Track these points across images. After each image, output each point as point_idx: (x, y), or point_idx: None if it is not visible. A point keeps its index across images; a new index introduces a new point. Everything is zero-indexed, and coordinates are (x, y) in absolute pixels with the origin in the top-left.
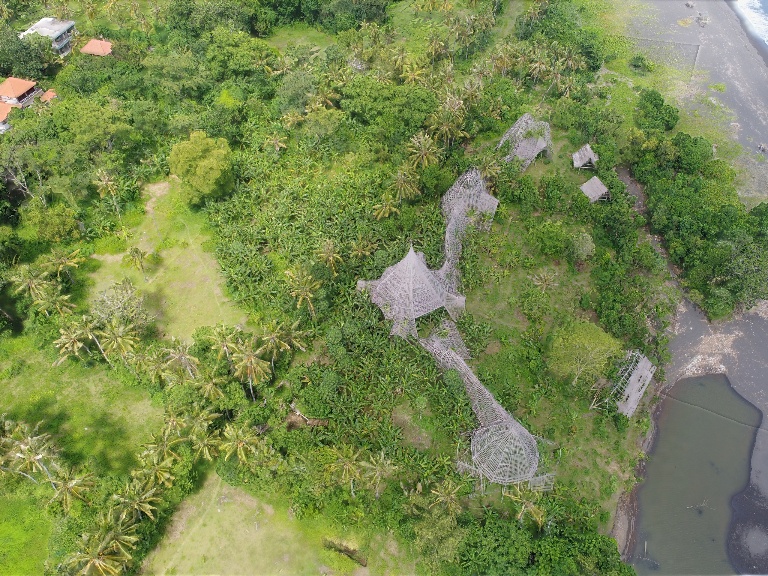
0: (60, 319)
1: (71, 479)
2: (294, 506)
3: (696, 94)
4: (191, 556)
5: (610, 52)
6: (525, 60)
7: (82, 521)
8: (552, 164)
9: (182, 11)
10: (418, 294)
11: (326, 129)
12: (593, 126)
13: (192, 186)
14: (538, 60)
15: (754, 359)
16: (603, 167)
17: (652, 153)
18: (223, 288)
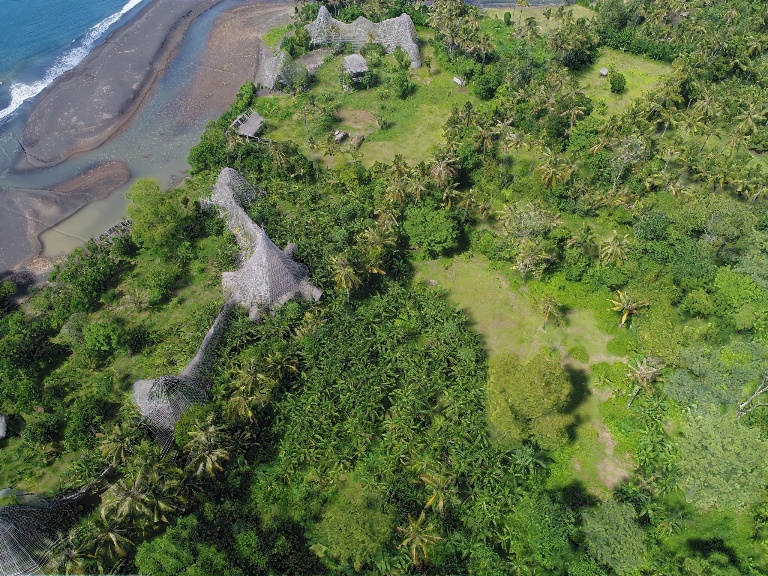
0: None
1: None
2: None
3: None
4: None
5: None
6: None
7: None
8: None
9: None
10: None
11: None
12: None
13: None
14: None
15: (4, 264)
16: None
17: None
18: None
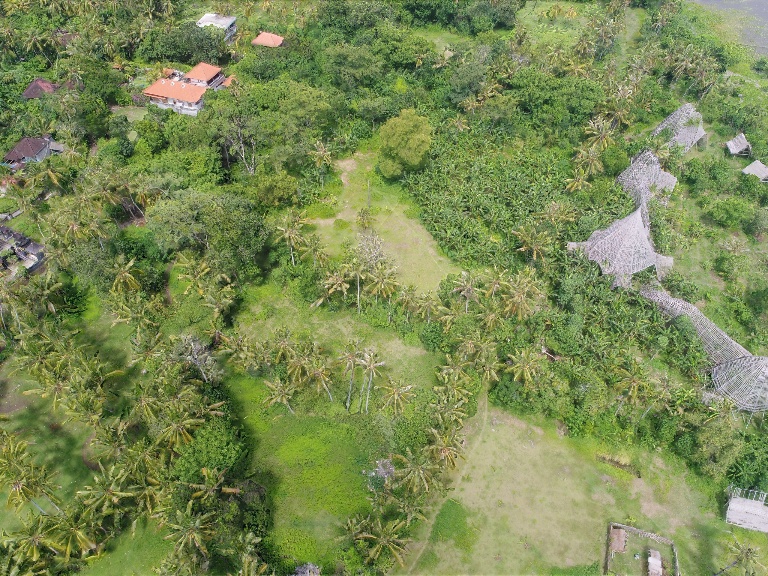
0: None
1: (401, 386)
2: (570, 424)
3: None
4: (480, 466)
5: (731, 57)
6: (671, 59)
7: (415, 422)
8: (706, 151)
9: (339, 10)
10: (638, 251)
11: (505, 113)
12: (741, 118)
13: (394, 159)
14: (685, 59)
15: None
16: (759, 153)
17: None
18: (436, 249)
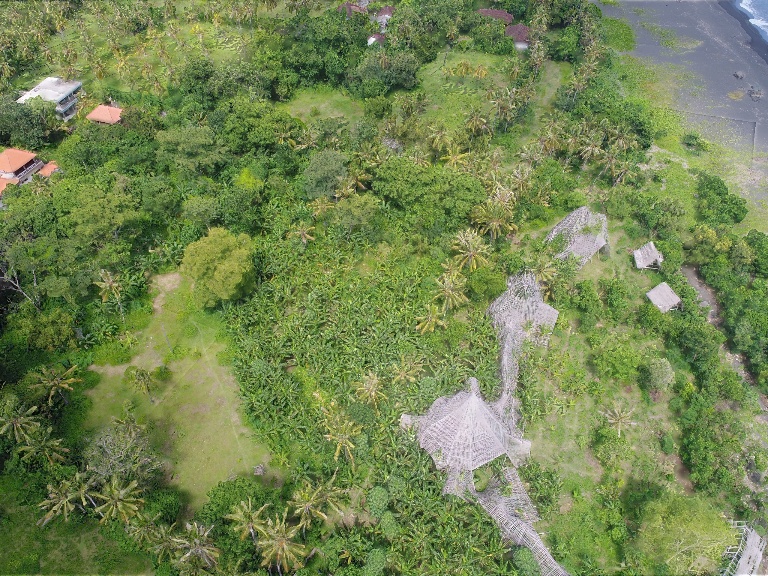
0: (49, 467)
1: None
2: None
3: (760, 180)
4: None
5: (659, 127)
6: (576, 141)
7: None
8: (610, 261)
9: (199, 75)
10: (478, 443)
11: (359, 220)
12: (654, 219)
13: None
14: (591, 142)
15: None
16: (670, 269)
17: (725, 254)
18: (242, 414)
